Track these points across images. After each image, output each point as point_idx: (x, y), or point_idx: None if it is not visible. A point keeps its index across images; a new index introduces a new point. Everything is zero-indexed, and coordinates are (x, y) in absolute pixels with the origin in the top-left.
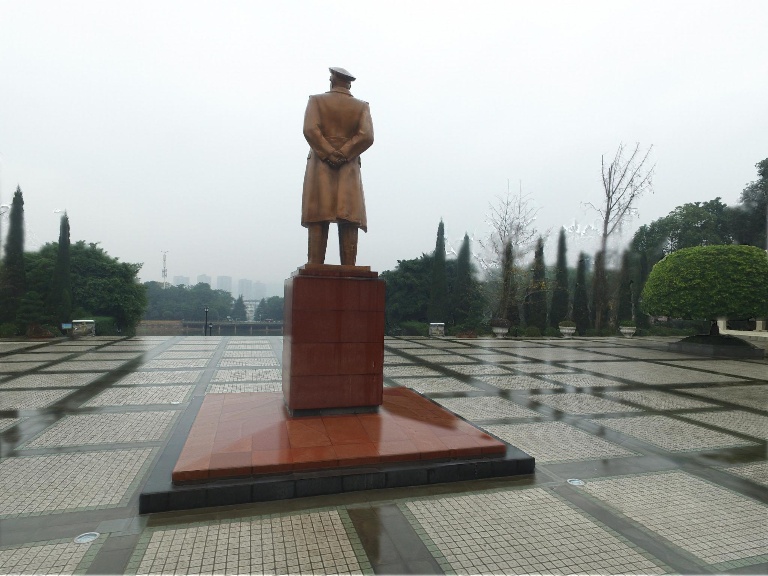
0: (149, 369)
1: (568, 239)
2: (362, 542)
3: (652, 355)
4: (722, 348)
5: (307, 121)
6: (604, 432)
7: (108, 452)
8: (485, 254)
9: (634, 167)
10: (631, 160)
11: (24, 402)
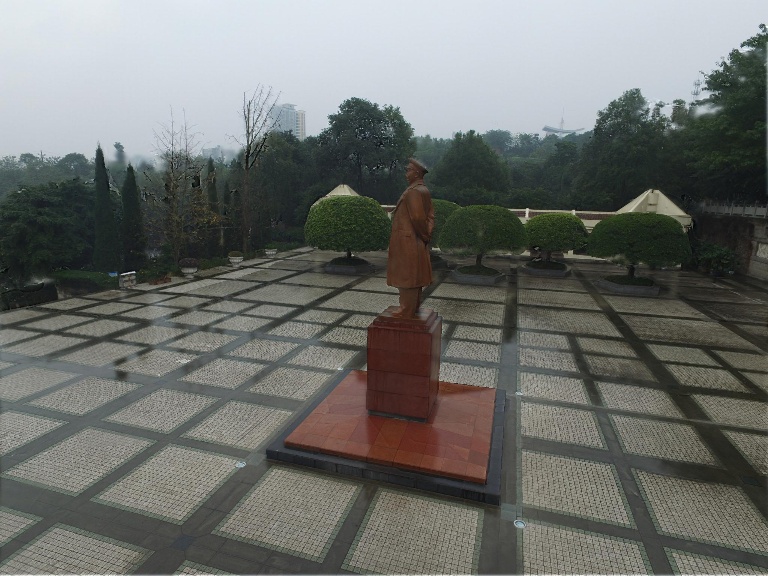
0: (2, 460)
1: (216, 170)
2: (555, 454)
3: (335, 281)
4: (359, 268)
5: (419, 212)
6: (465, 361)
7: (375, 511)
8: (153, 188)
9: (268, 109)
10: (265, 102)
11: (85, 569)
